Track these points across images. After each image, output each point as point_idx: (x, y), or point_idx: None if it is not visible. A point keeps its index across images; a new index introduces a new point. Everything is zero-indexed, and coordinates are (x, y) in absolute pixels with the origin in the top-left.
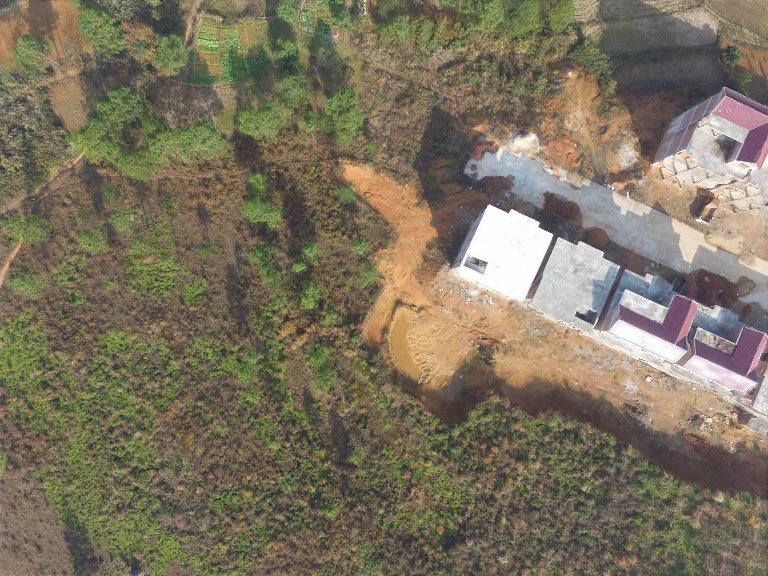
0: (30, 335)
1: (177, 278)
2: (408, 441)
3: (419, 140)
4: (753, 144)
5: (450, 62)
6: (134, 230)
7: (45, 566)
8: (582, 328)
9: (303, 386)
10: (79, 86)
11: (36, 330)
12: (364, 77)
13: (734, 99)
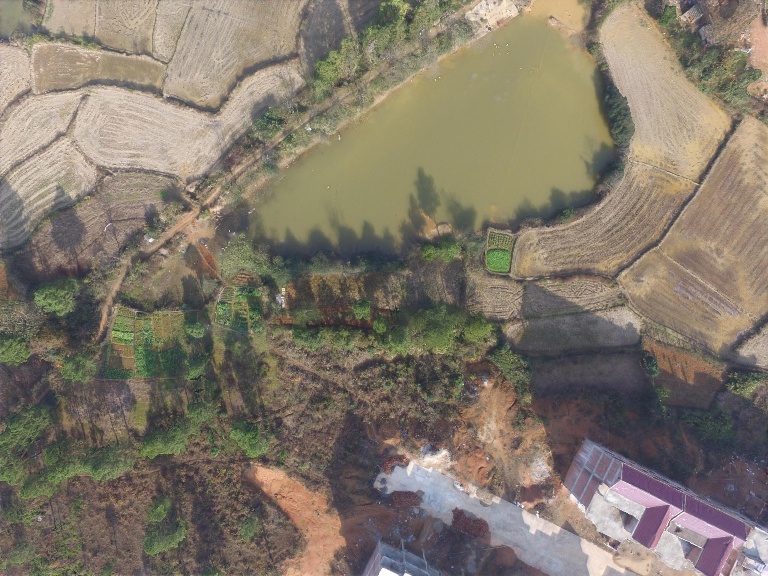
0: None
1: None
2: None
3: (331, 446)
4: (648, 526)
5: (367, 361)
6: (41, 531)
7: None
8: None
9: None
10: None
11: None
12: (279, 375)
13: (630, 483)
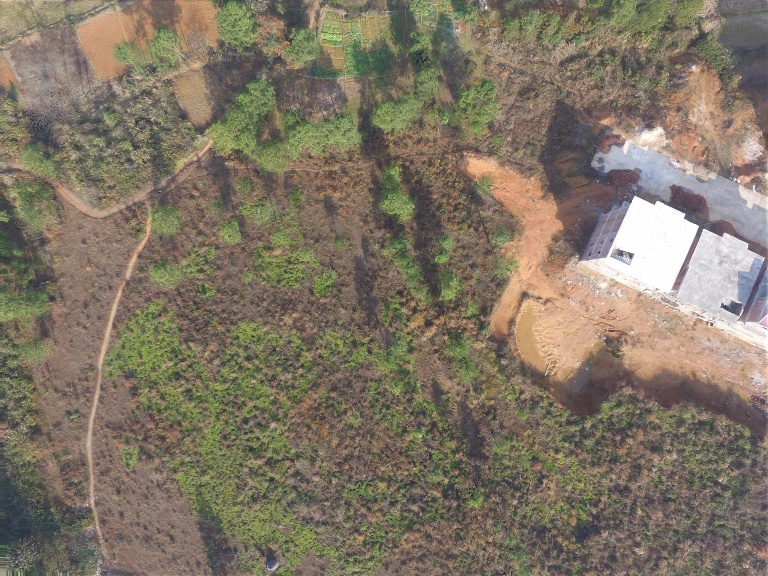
0: (160, 326)
1: (306, 270)
2: (538, 432)
3: (544, 133)
4: None
5: (572, 56)
6: (262, 222)
7: (178, 556)
8: (728, 319)
9: (432, 378)
10: (203, 79)
11: (167, 321)
12: (487, 71)
13: None
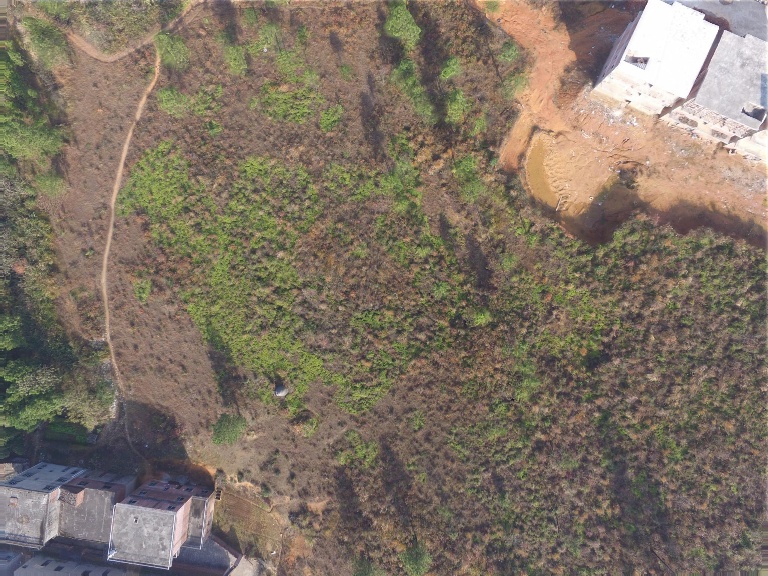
0: (170, 164)
1: (312, 106)
2: (548, 265)
3: None
4: None
5: None
6: (268, 60)
7: (190, 386)
8: (749, 125)
9: (439, 212)
10: None
11: (176, 158)
12: None
13: None
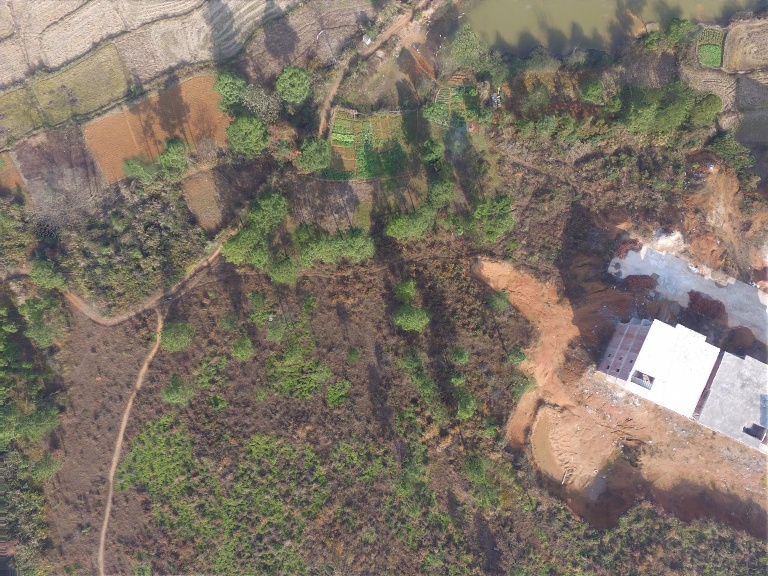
0: (172, 438)
1: (319, 379)
2: (555, 545)
3: (559, 236)
4: None
5: (587, 155)
6: None
7: None
8: (750, 444)
9: (447, 488)
10: (212, 181)
11: (178, 434)
12: (500, 171)
13: None
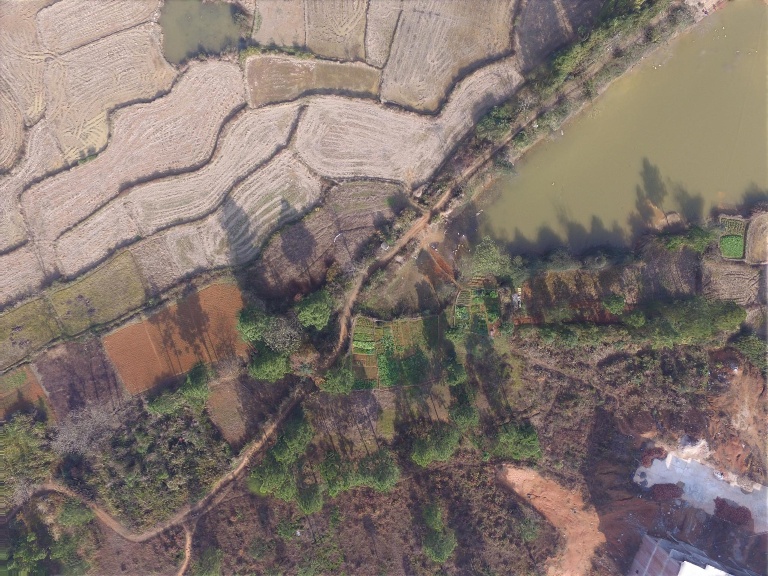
0: None
1: None
2: None
3: (583, 443)
4: None
5: (609, 356)
6: (302, 546)
7: None
8: None
9: None
10: (234, 392)
11: None
12: (523, 375)
13: None
